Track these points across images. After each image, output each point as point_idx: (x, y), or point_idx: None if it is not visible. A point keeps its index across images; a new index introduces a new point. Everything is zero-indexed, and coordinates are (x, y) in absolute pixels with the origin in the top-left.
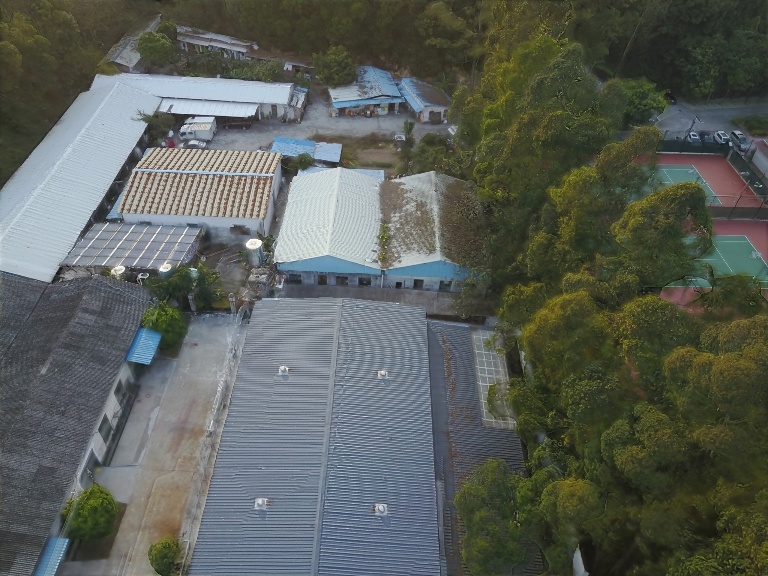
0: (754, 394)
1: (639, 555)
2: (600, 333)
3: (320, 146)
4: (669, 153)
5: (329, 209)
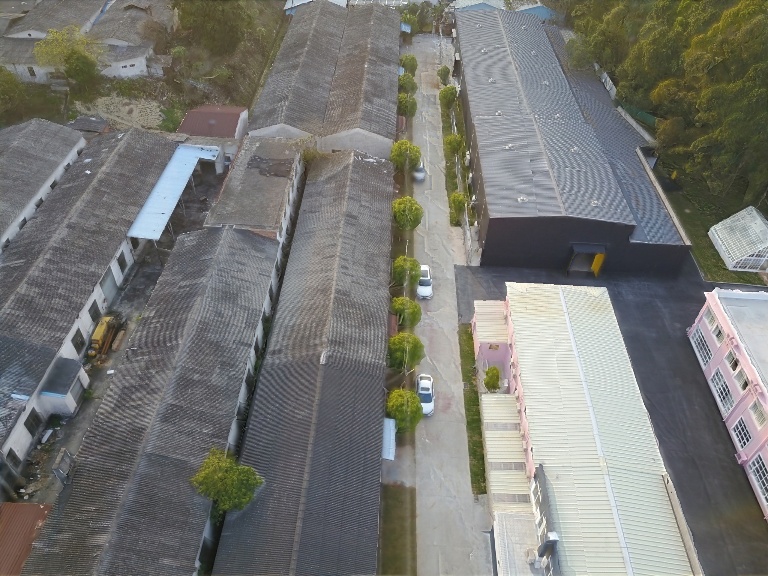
0: None
1: (639, 28)
2: None
3: None
4: None
5: None
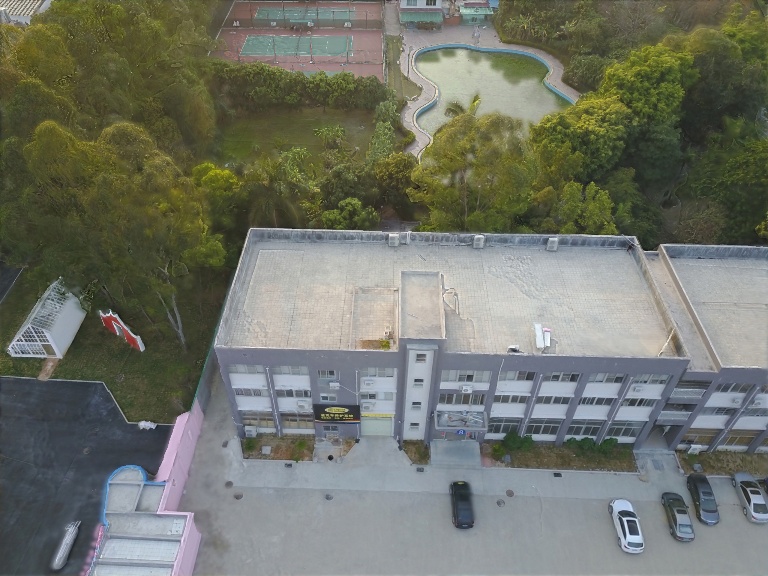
0: None
1: None
2: None
3: None
4: (344, 2)
5: None
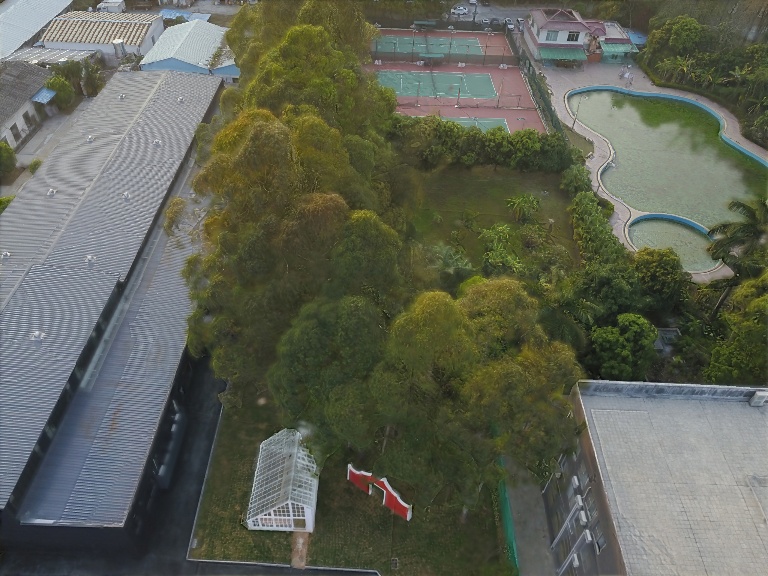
0: (272, 7)
1: None
2: (251, 21)
3: (194, 14)
4: (464, 31)
5: (182, 38)
